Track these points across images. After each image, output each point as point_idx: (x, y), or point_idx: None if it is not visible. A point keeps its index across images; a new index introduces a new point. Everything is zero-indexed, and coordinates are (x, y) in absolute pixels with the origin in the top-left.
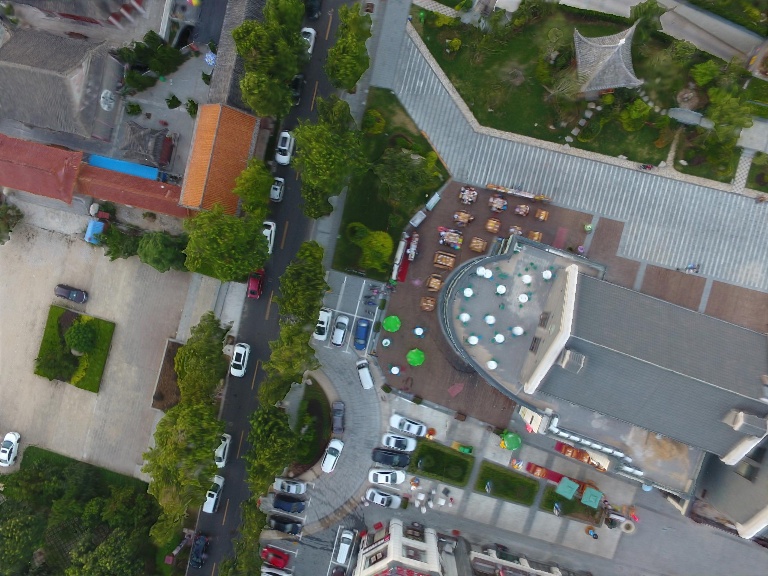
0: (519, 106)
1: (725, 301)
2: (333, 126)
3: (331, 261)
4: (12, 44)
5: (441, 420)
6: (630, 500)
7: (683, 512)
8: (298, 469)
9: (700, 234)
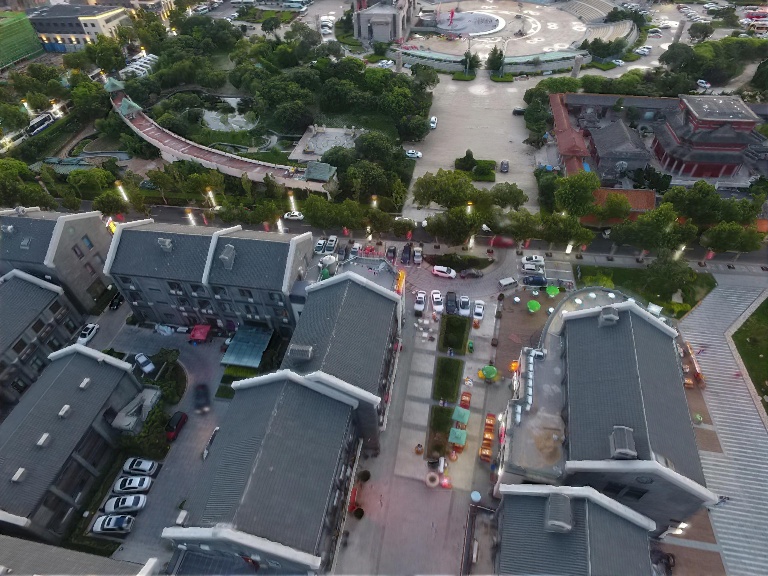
0: (766, 357)
1: (704, 569)
2: (678, 227)
3: (577, 264)
4: (632, 130)
5: (488, 332)
6: (456, 485)
7: (473, 505)
8: (429, 259)
9: (759, 532)
